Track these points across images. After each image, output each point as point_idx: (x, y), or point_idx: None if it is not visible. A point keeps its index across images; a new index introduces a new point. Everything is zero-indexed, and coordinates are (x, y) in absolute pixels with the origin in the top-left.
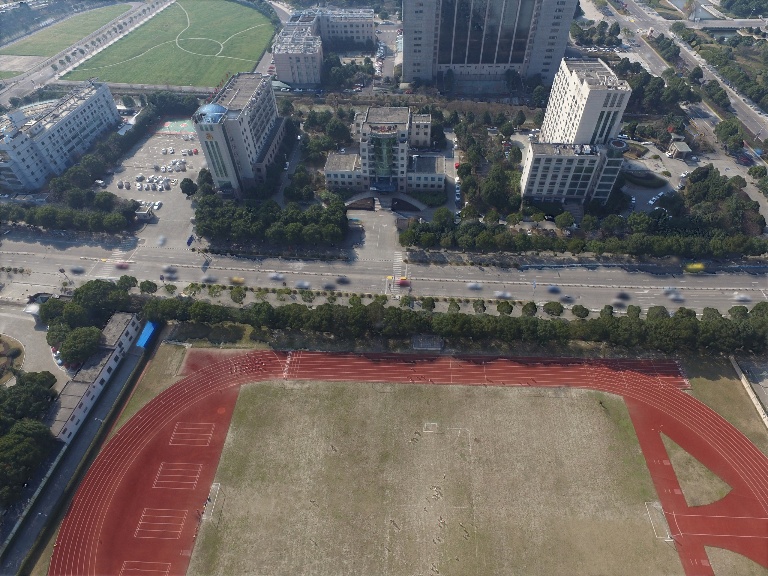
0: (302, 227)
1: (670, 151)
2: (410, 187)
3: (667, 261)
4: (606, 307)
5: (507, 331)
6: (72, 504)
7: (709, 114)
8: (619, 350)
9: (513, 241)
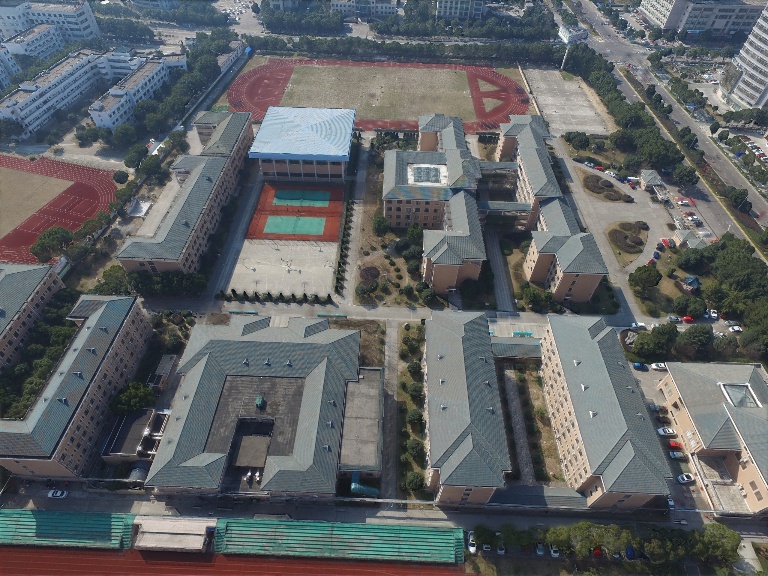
0: (320, 19)
1: (525, 9)
2: (377, 14)
3: None
4: None
5: (417, 47)
6: (230, 87)
7: None
8: (469, 62)
9: (427, 27)
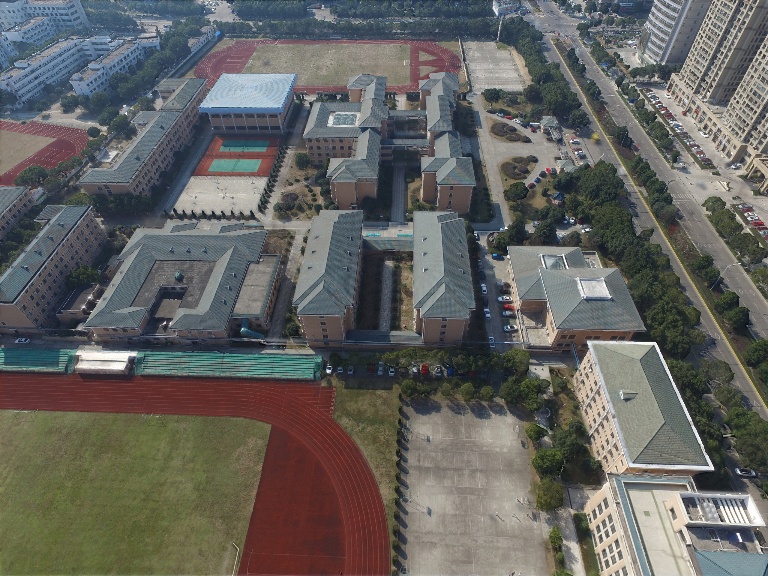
0: (285, 6)
1: None
2: None
3: None
4: None
5: (367, 25)
6: (198, 64)
7: None
8: (415, 37)
9: None
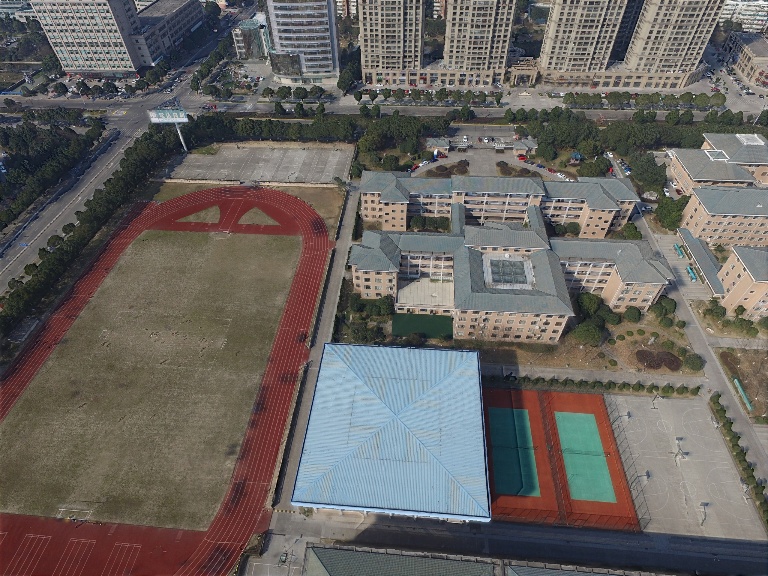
0: None
1: None
2: None
3: (64, 182)
4: (76, 214)
5: (54, 266)
6: None
7: None
8: (113, 223)
9: None
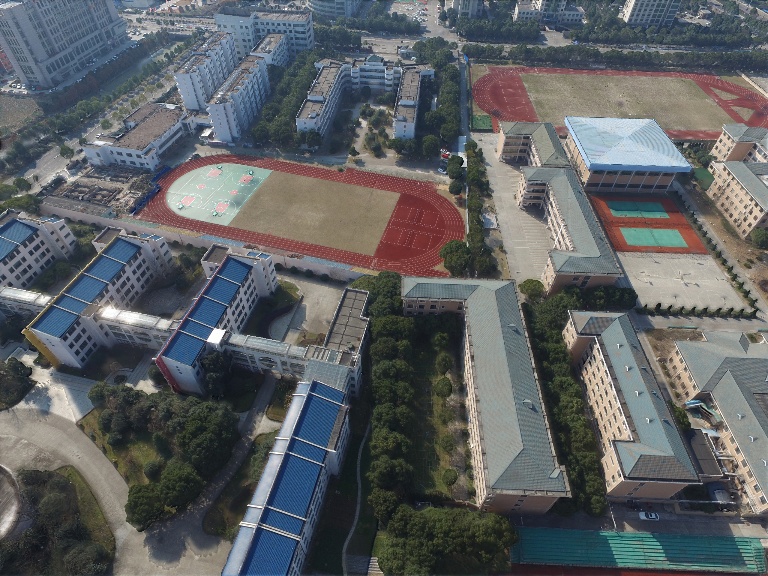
0: None
1: (699, 15)
2: (563, 21)
3: (704, 49)
4: None
5: (638, 55)
6: (473, 96)
7: (718, 5)
8: (687, 70)
9: (629, 35)
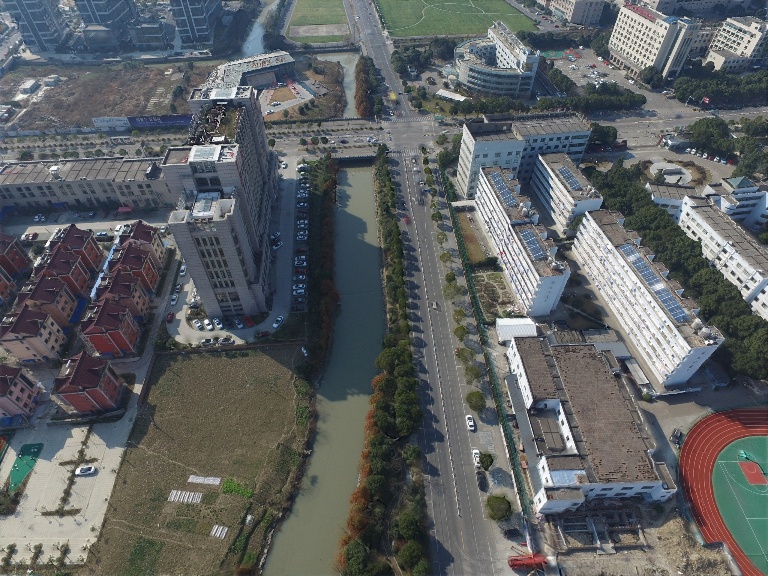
0: None
1: None
2: None
3: None
4: None
5: None
6: None
7: None
8: None
9: None
